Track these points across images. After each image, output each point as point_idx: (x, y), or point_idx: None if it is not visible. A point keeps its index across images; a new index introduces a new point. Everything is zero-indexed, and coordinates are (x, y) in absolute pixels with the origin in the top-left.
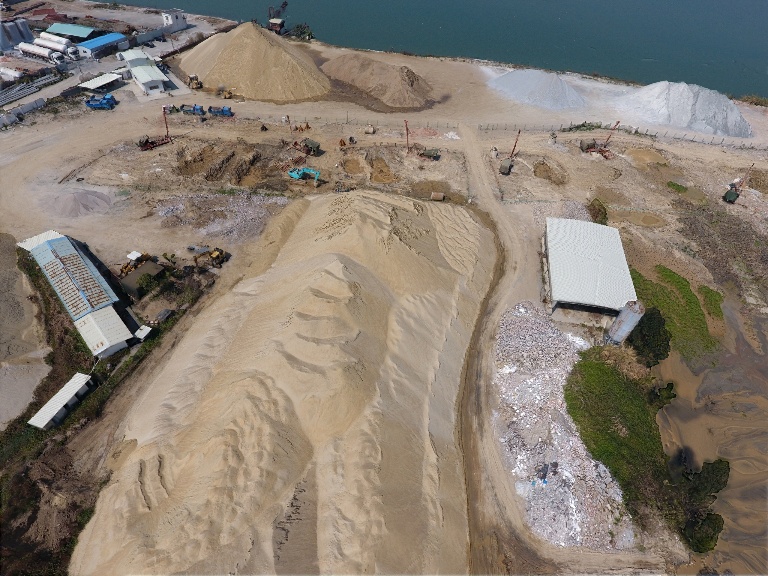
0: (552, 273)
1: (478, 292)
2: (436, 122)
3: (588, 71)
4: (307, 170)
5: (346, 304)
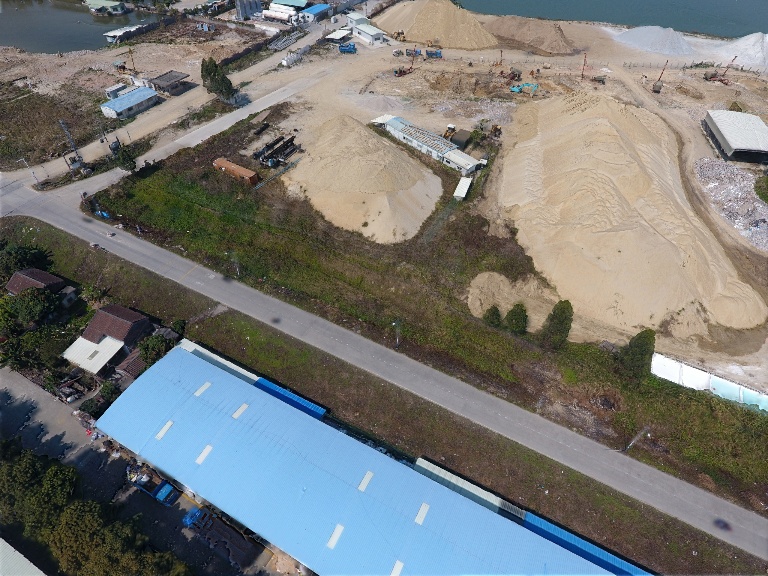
0: (725, 136)
1: (674, 151)
2: (590, 62)
3: (689, 30)
4: (527, 85)
5: (620, 137)
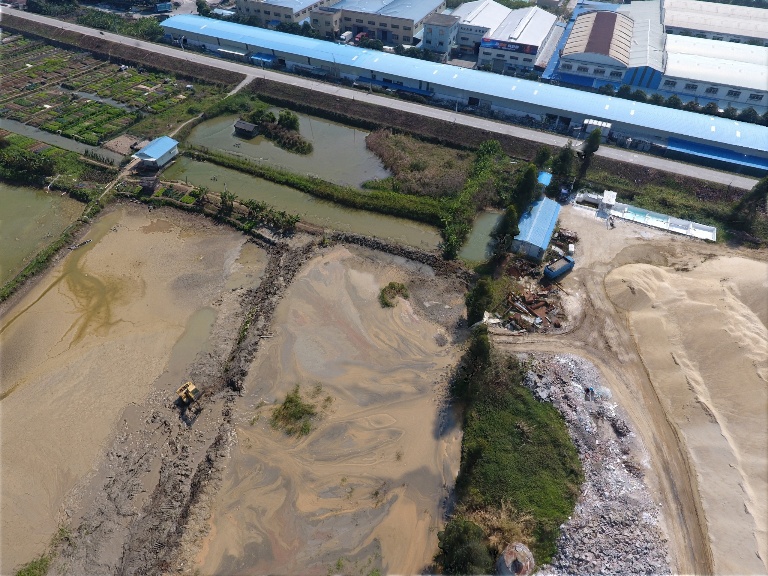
0: None
1: None
2: None
3: None
4: None
5: None
